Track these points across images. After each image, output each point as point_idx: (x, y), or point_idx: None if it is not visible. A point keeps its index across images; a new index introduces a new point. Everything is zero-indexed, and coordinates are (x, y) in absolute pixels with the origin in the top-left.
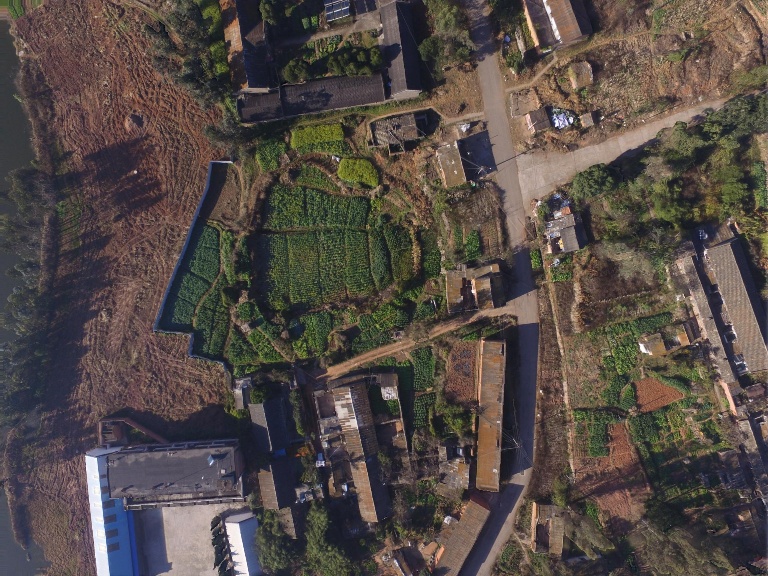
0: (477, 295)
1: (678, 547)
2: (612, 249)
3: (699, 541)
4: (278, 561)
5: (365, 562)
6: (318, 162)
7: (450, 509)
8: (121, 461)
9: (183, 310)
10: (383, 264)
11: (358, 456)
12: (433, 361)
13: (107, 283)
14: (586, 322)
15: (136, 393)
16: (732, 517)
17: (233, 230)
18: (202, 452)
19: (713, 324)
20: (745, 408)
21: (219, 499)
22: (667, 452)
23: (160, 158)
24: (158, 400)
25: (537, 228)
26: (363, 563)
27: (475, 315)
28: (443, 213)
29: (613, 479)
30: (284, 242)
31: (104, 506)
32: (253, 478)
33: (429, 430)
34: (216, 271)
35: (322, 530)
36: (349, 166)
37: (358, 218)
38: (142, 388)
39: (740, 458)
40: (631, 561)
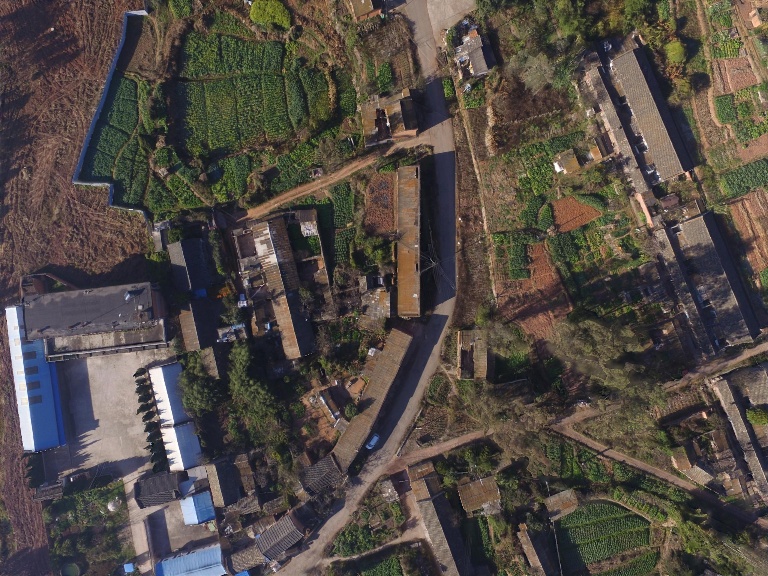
0: (389, 120)
1: (587, 331)
2: (515, 57)
3: (625, 360)
4: (200, 399)
5: (293, 405)
6: (231, 7)
7: (374, 343)
8: (37, 302)
9: (103, 163)
10: (300, 106)
11: (279, 292)
12: (352, 196)
13: (27, 141)
14: (500, 145)
15: (58, 249)
16: (657, 334)
17: (150, 79)
18: (118, 289)
19: (623, 133)
20: (660, 218)
21: (141, 345)
22: (588, 272)
23: (76, 14)
24: (80, 254)
25: (448, 57)
26: (291, 406)
27: (391, 148)
28: (355, 47)
29: (536, 301)
30: (201, 90)
31: (25, 357)
32: (175, 322)
33: (349, 262)
34: (135, 122)
35: (244, 365)
36: (261, 7)
37: (273, 62)
38: (64, 243)
39: (661, 272)
40: (558, 384)
